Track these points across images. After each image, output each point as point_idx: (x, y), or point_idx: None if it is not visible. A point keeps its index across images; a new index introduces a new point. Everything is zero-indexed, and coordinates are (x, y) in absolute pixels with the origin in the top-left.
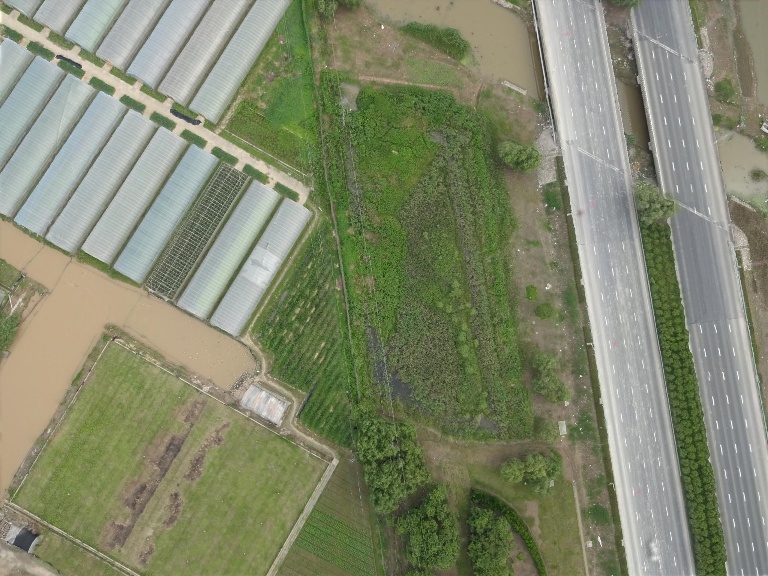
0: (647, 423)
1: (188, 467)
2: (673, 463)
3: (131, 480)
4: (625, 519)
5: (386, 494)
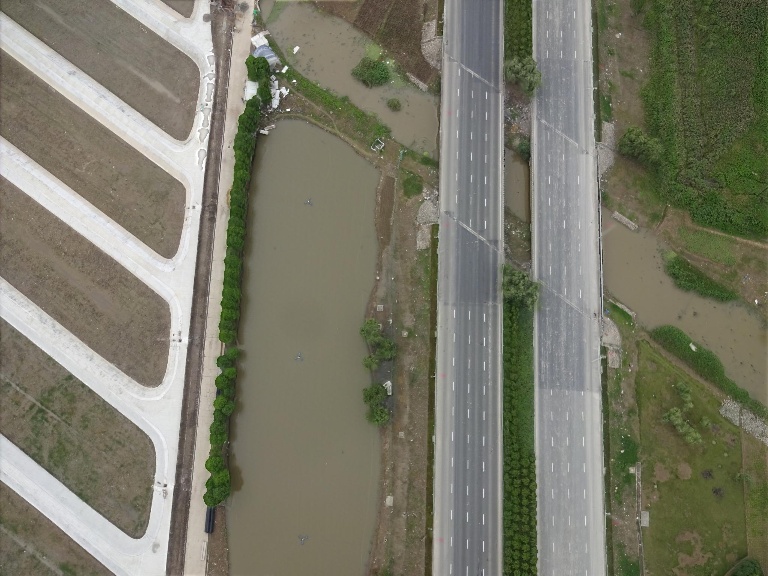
0: None
1: None
2: None
3: None
4: None
5: None
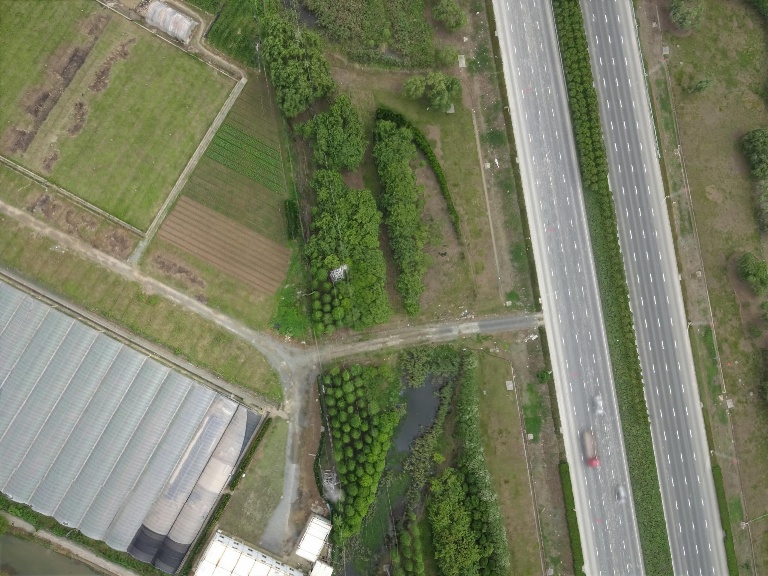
0: (538, 56)
1: (93, 78)
2: (562, 92)
3: (33, 88)
4: (519, 140)
5: (292, 89)
